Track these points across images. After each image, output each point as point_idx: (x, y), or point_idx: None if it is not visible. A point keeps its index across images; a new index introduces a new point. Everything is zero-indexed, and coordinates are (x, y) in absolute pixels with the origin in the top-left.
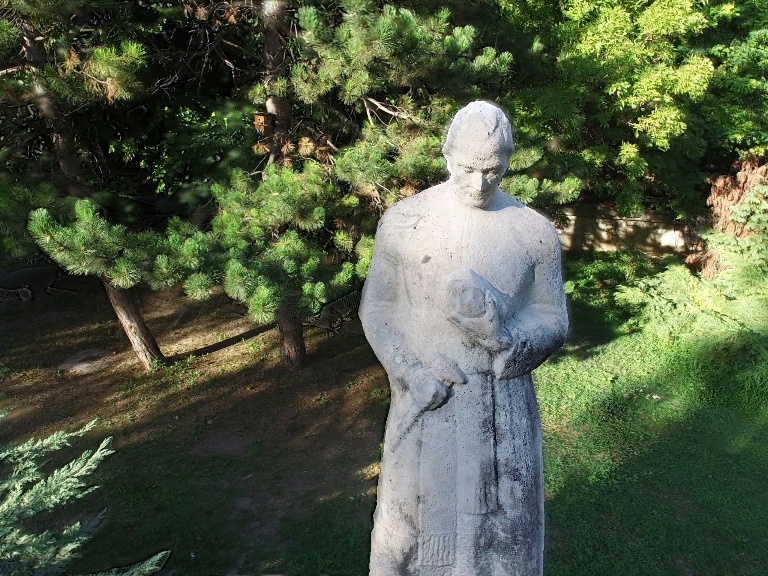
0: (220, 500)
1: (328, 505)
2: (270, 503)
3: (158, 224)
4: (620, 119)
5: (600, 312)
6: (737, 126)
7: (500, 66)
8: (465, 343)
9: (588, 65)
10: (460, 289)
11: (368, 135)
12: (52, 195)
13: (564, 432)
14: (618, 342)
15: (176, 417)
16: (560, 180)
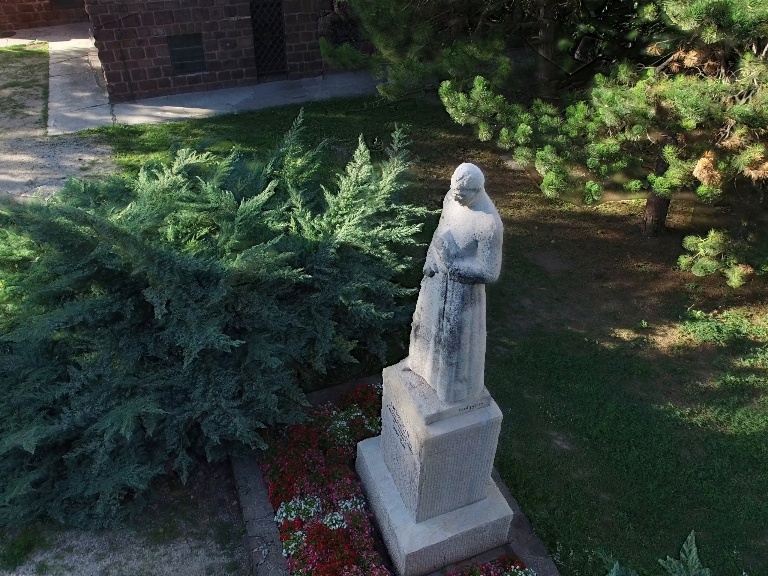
0: (515, 292)
1: (568, 333)
2: (539, 311)
3: (526, 102)
4: None
5: None
6: None
7: None
8: None
9: None
10: None
11: (746, 66)
12: (494, 53)
13: None
14: None
15: (537, 227)
16: None
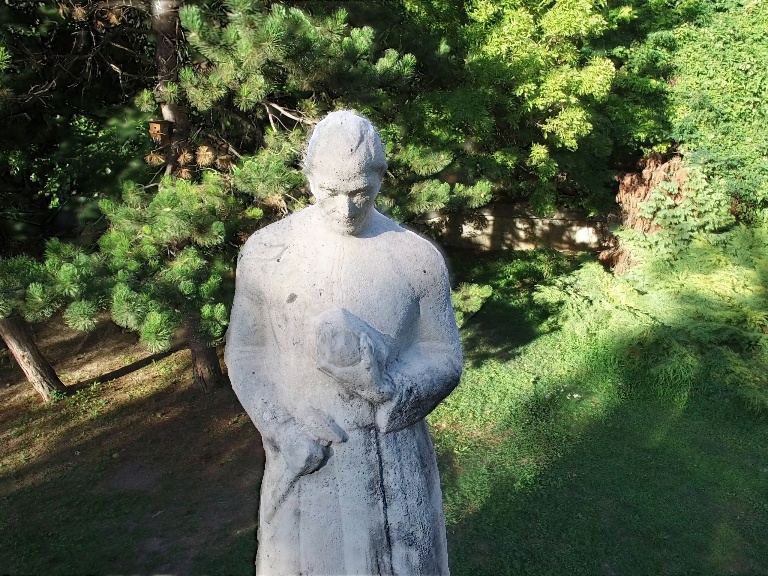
0: (126, 543)
1: (245, 538)
2: (182, 541)
3: (33, 247)
4: (529, 120)
5: (521, 312)
6: (640, 125)
7: (404, 68)
8: (343, 394)
9: (495, 67)
10: (330, 334)
11: (271, 142)
12: None
13: (489, 438)
14: (539, 341)
15: (77, 453)
16: (473, 183)
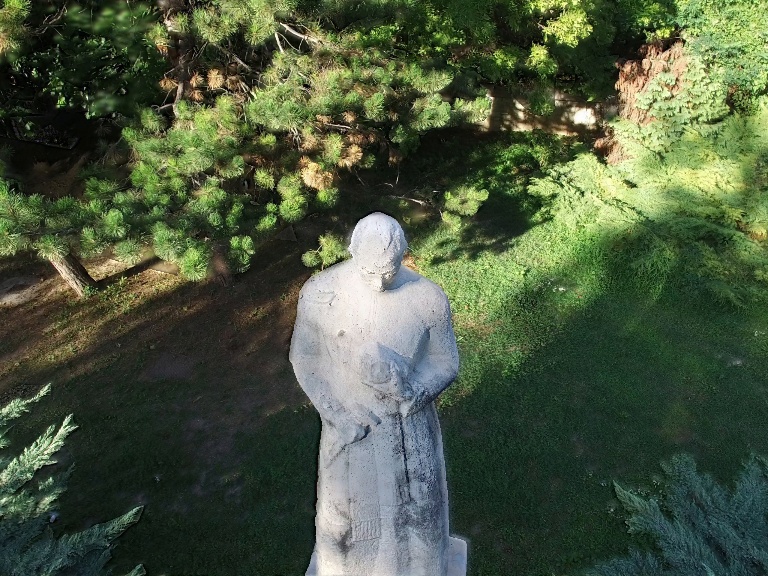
0: (175, 424)
1: (275, 420)
2: (222, 423)
3: (76, 188)
4: (530, 20)
5: (516, 201)
6: (645, 8)
7: None
8: (378, 395)
9: None
10: (370, 364)
11: (279, 65)
12: None
13: (482, 329)
14: (531, 233)
15: (119, 345)
16: (472, 93)
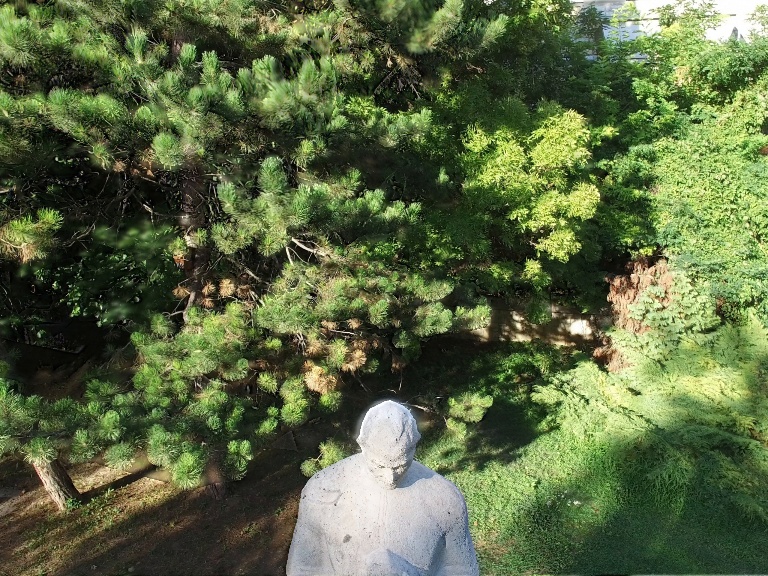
0: None
1: None
2: None
3: (76, 390)
4: (523, 239)
5: (520, 410)
6: (627, 230)
7: (410, 216)
8: None
9: (490, 195)
10: None
11: (288, 276)
12: None
13: (494, 549)
14: (538, 442)
15: (94, 567)
16: (472, 302)
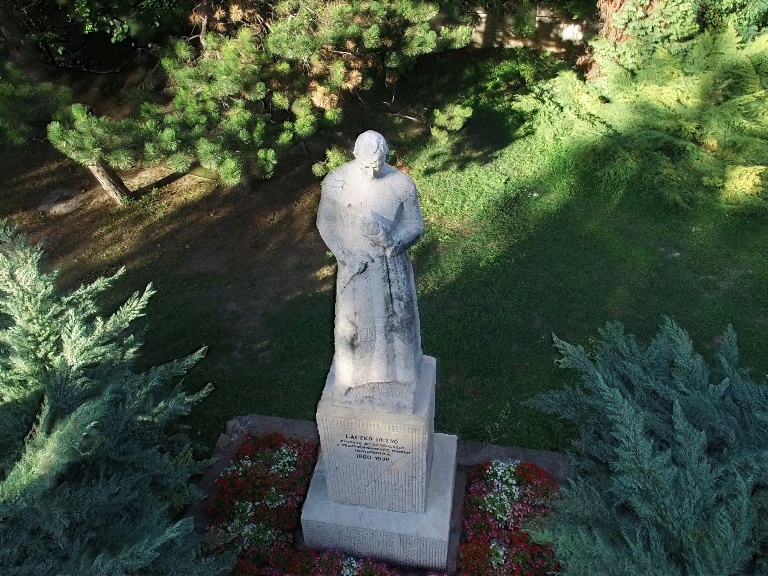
0: (213, 306)
1: (294, 301)
2: (251, 304)
3: (134, 111)
4: None
5: (502, 117)
6: None
7: None
8: (372, 244)
9: None
10: (367, 223)
11: (290, 1)
12: (29, 83)
13: (465, 229)
14: (514, 145)
15: (159, 245)
16: (458, 20)
